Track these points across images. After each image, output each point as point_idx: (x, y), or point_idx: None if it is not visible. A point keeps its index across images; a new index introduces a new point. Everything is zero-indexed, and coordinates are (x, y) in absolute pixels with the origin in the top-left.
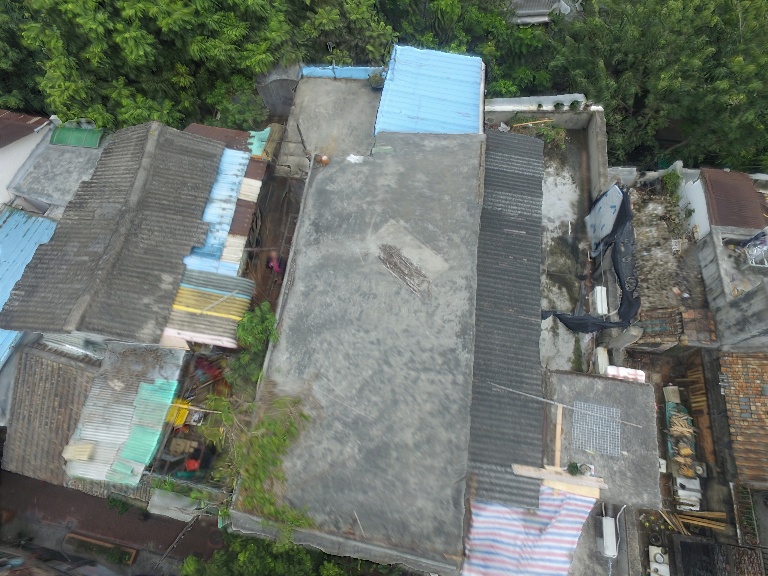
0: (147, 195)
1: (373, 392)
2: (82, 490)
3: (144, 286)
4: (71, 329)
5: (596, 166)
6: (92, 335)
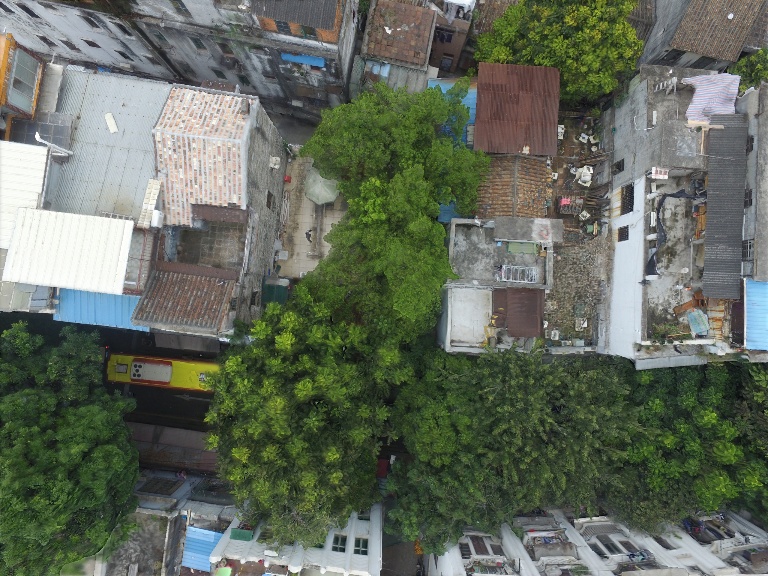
0: None
1: None
2: None
3: None
4: None
5: None
6: None
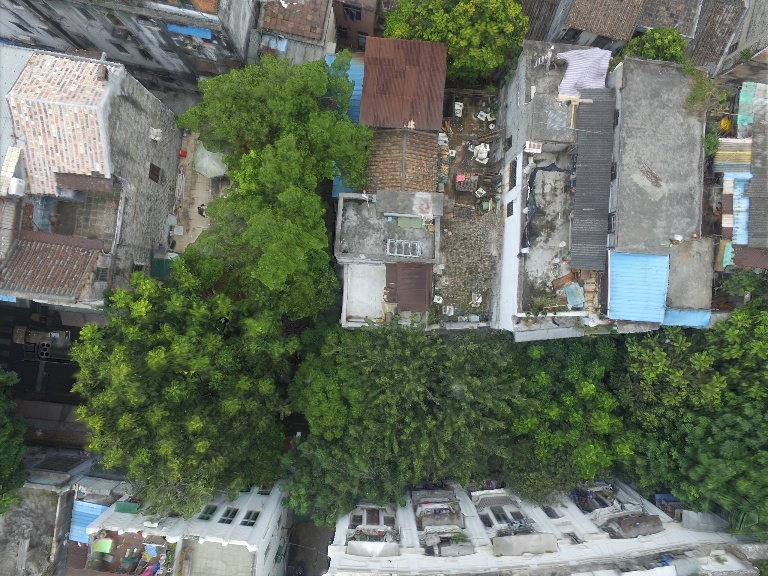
0: None
1: (658, 119)
2: None
3: None
4: None
5: None
6: None
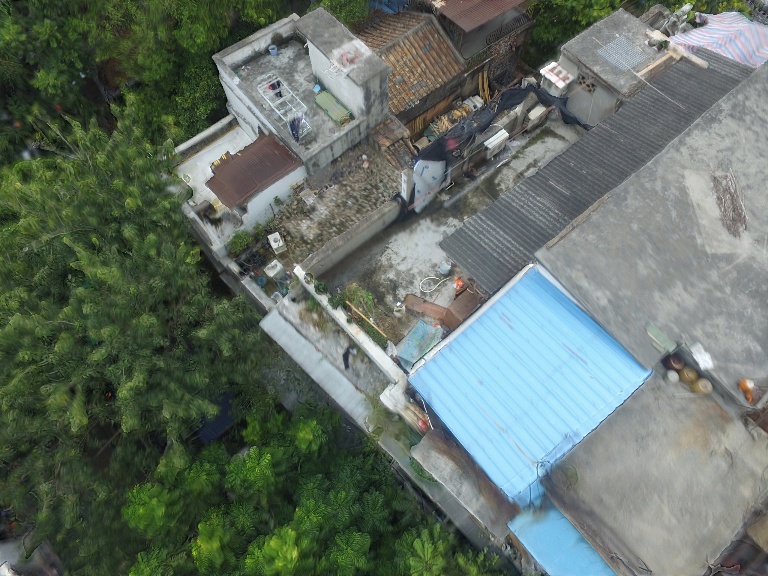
0: None
1: None
2: None
3: None
4: None
5: None
6: None
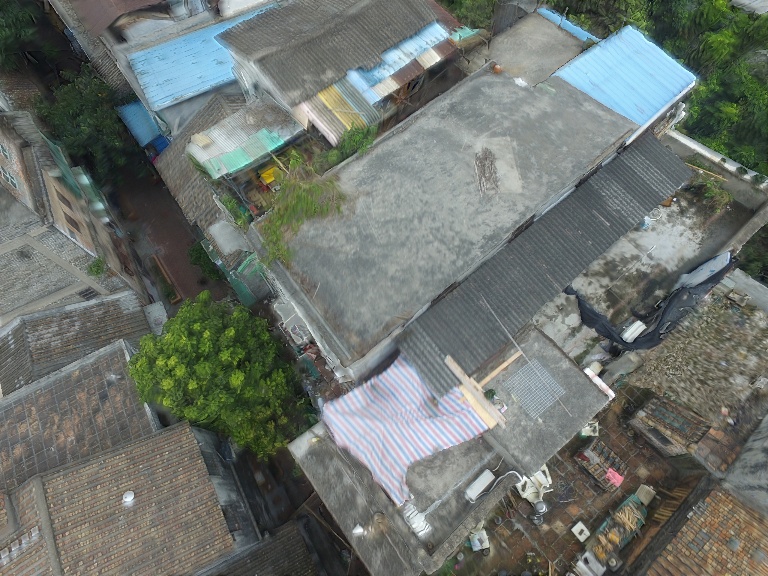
0: (359, 15)
1: (394, 229)
2: (183, 210)
3: (311, 68)
4: (251, 59)
5: (732, 240)
6: (260, 77)
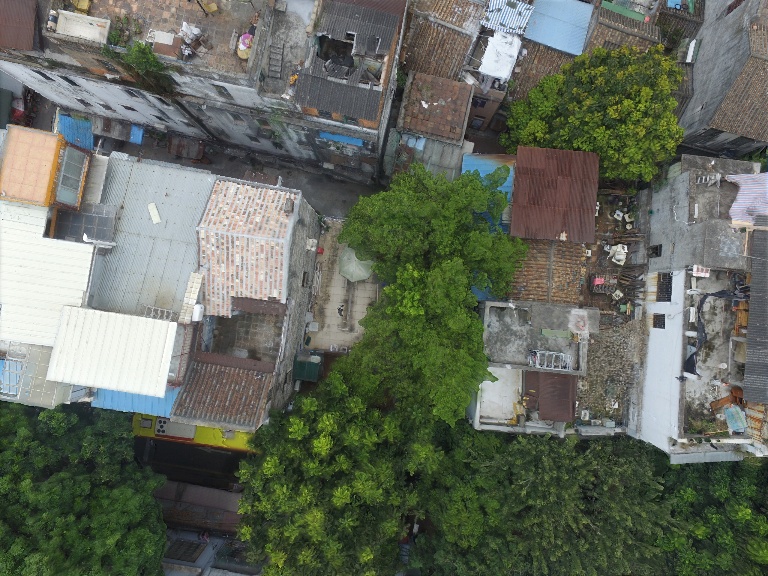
0: None
1: None
2: None
3: None
4: None
5: None
6: None
